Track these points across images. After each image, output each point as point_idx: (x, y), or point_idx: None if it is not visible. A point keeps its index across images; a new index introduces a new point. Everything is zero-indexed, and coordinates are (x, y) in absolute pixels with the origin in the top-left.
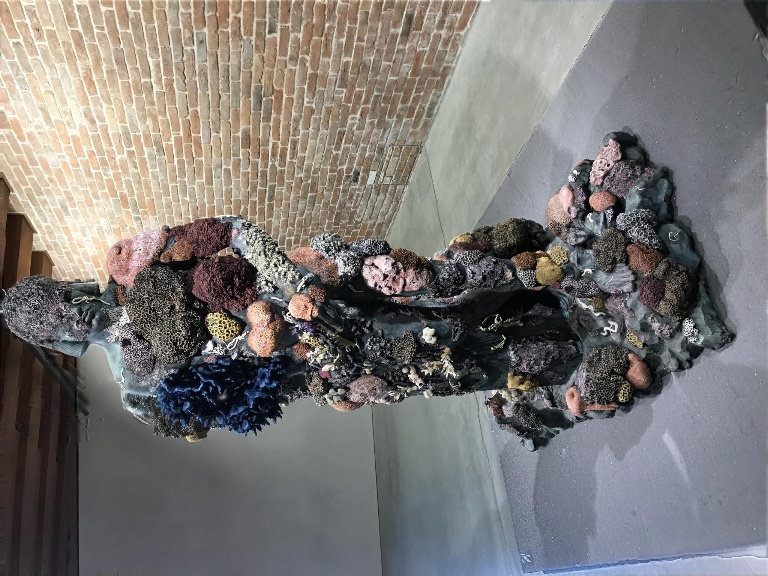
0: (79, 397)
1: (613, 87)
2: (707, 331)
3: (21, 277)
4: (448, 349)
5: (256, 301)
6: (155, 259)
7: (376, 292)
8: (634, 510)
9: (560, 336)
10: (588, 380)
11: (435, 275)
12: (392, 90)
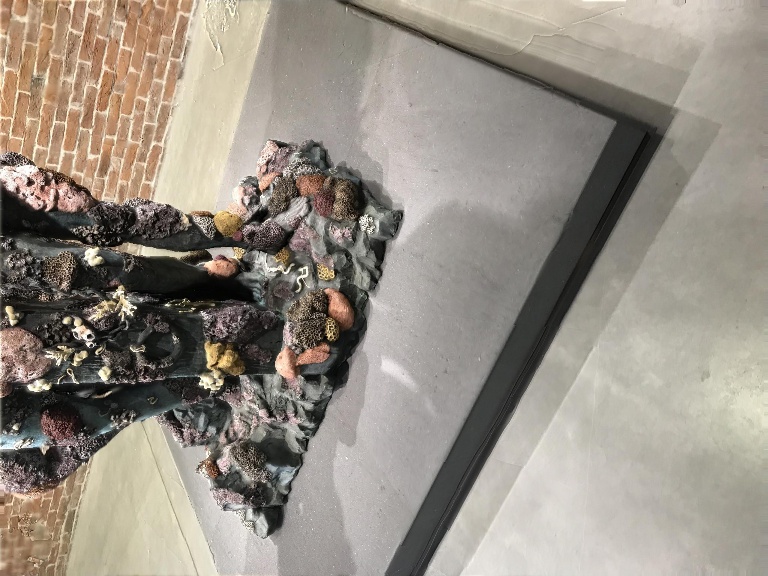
0: None
1: (265, 128)
2: (380, 215)
3: None
4: (121, 287)
5: None
6: None
7: (20, 206)
8: (381, 484)
9: None
10: (292, 328)
11: (97, 203)
12: None
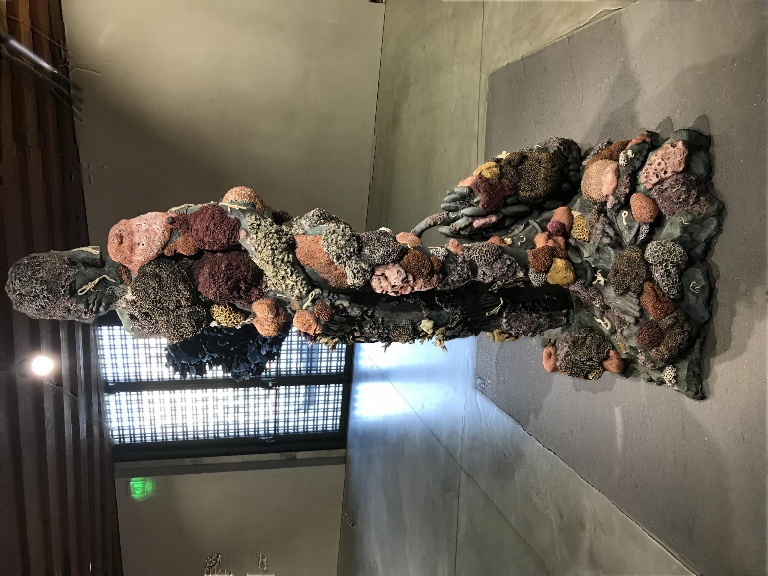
0: (77, 129)
1: (714, 57)
2: (683, 386)
3: None
4: (443, 327)
5: (261, 298)
6: (159, 253)
7: None
8: (572, 431)
9: (556, 304)
10: (567, 355)
11: (445, 277)
12: None
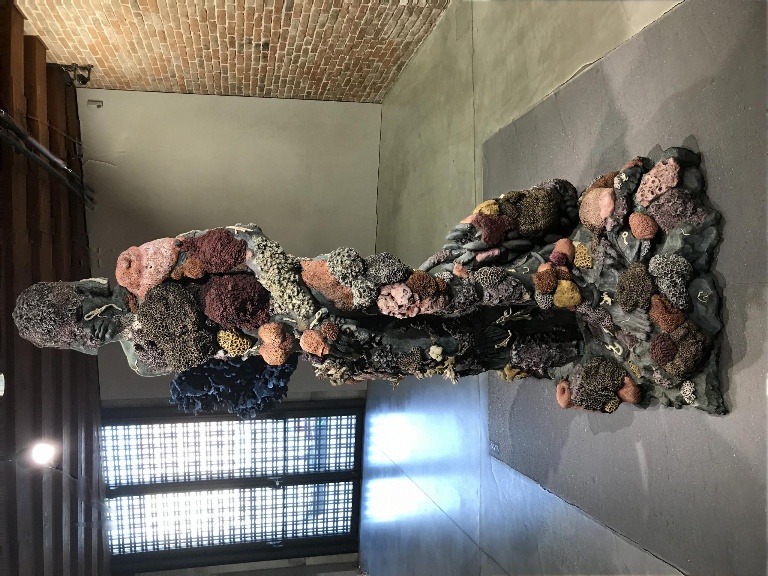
0: (88, 217)
1: (694, 81)
2: (704, 401)
3: (17, 82)
4: (452, 357)
5: (268, 322)
6: (166, 276)
7: None
8: (594, 478)
9: (565, 335)
10: (581, 387)
11: (451, 299)
12: None
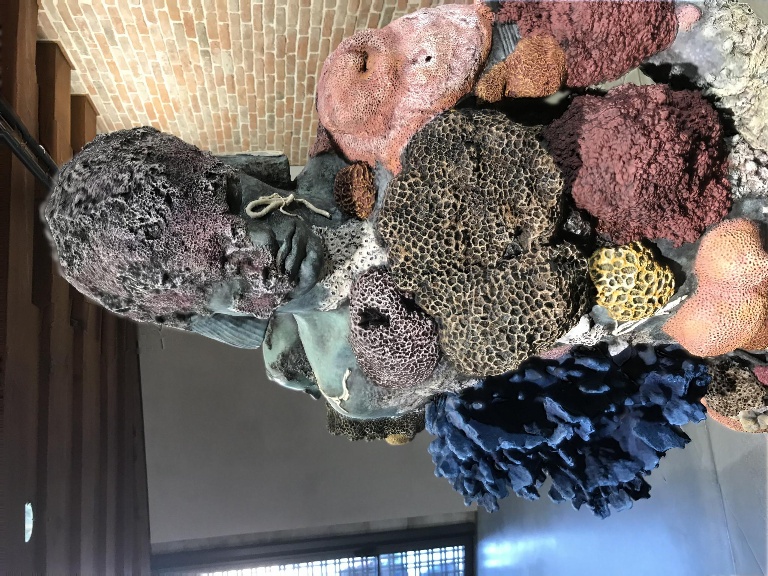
0: None
1: None
2: None
3: (62, 129)
4: None
5: (727, 218)
6: (465, 89)
7: None
8: None
9: None
10: None
11: None
12: None
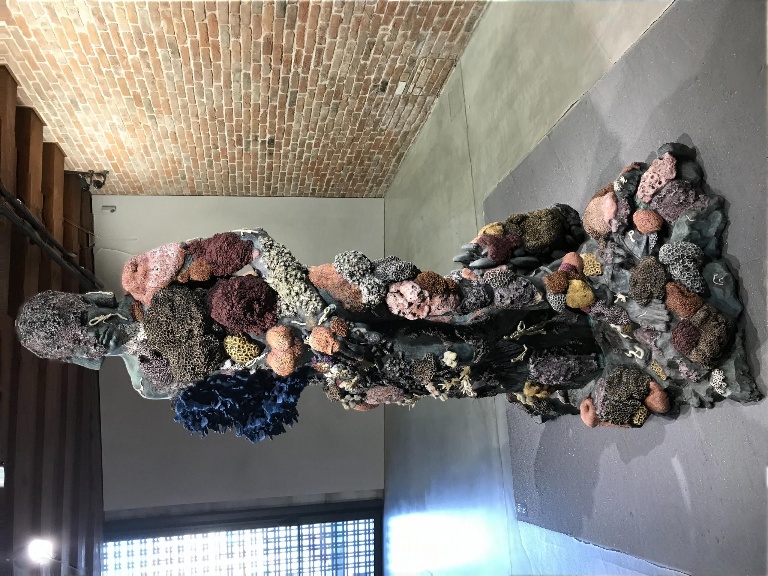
0: None
1: (679, 84)
2: (736, 387)
3: (35, 179)
4: (468, 367)
5: (276, 325)
6: (173, 279)
7: (399, 316)
8: (632, 512)
9: (583, 348)
10: (605, 399)
11: (461, 299)
12: (430, 2)
